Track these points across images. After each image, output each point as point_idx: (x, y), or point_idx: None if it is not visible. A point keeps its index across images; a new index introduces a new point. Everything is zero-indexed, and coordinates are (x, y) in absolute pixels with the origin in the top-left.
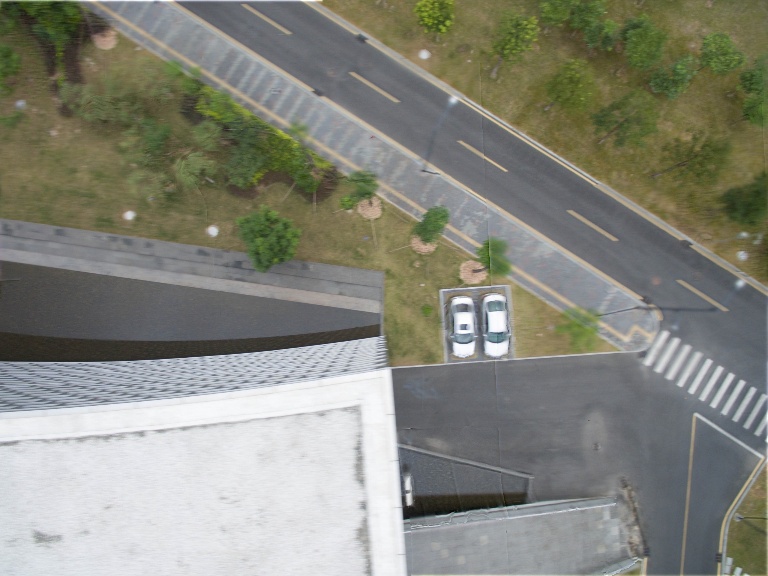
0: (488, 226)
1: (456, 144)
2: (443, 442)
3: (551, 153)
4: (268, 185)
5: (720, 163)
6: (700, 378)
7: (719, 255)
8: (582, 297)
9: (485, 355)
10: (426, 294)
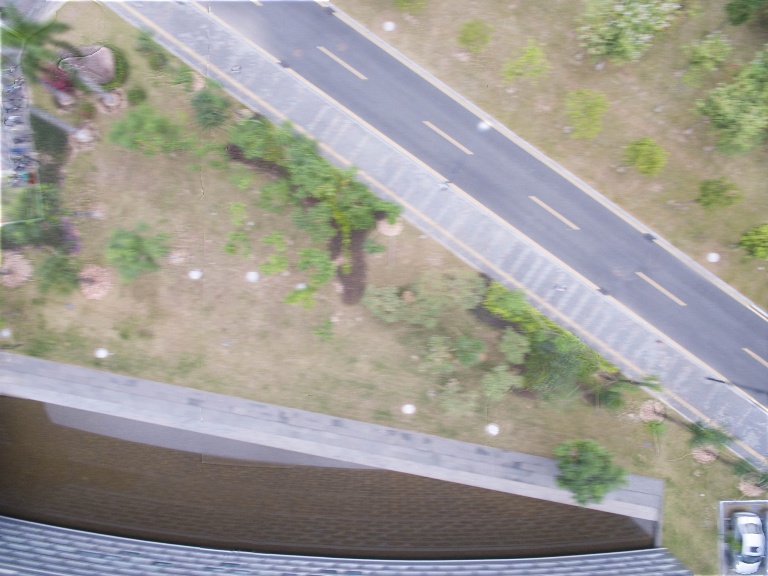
0: None
1: (741, 352)
2: None
3: None
4: (554, 387)
5: None
6: None
7: None
8: None
9: (767, 573)
10: (706, 505)
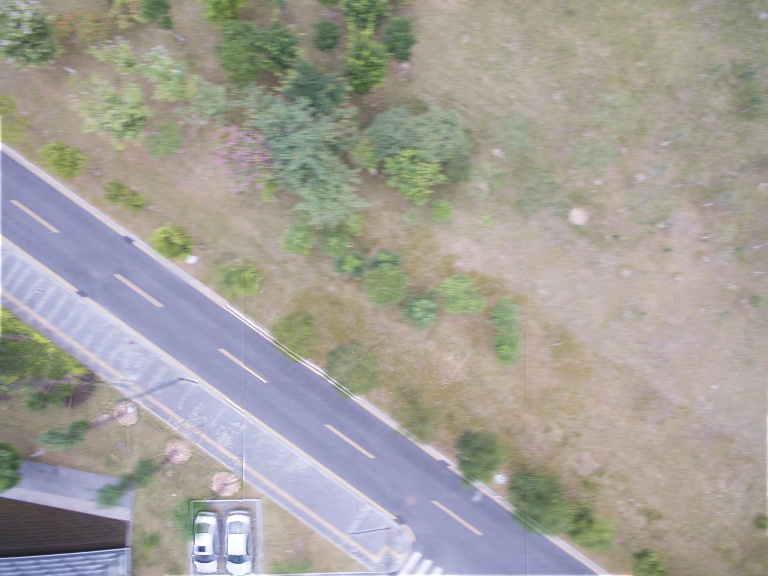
0: (243, 438)
1: (217, 352)
2: None
3: (312, 365)
4: (22, 389)
5: (480, 385)
6: None
7: (476, 478)
8: (334, 514)
9: (229, 573)
10: (177, 504)
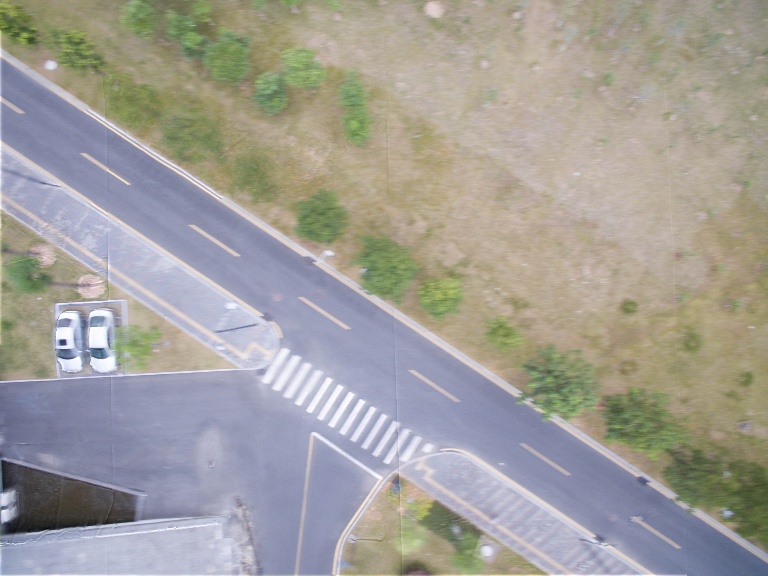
0: (108, 240)
1: (79, 156)
2: (56, 458)
3: (175, 167)
4: None
5: (342, 179)
6: (319, 397)
7: (341, 272)
8: (201, 313)
9: (94, 371)
10: (43, 308)
